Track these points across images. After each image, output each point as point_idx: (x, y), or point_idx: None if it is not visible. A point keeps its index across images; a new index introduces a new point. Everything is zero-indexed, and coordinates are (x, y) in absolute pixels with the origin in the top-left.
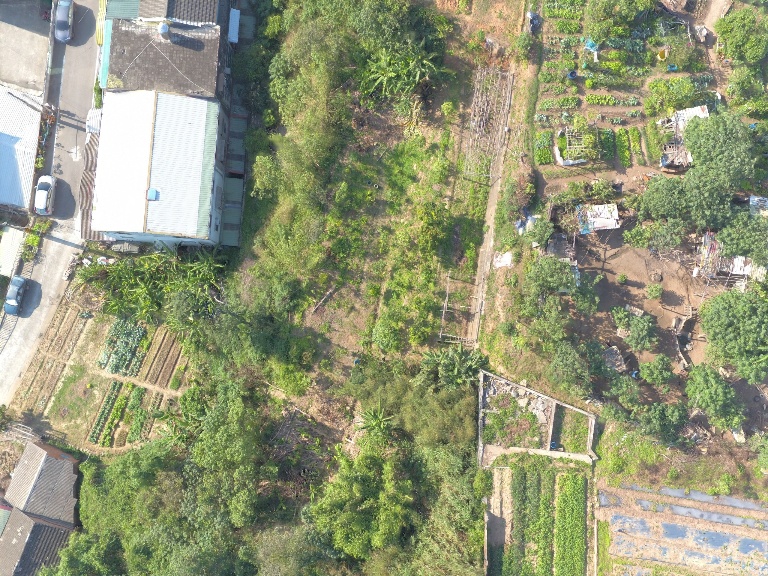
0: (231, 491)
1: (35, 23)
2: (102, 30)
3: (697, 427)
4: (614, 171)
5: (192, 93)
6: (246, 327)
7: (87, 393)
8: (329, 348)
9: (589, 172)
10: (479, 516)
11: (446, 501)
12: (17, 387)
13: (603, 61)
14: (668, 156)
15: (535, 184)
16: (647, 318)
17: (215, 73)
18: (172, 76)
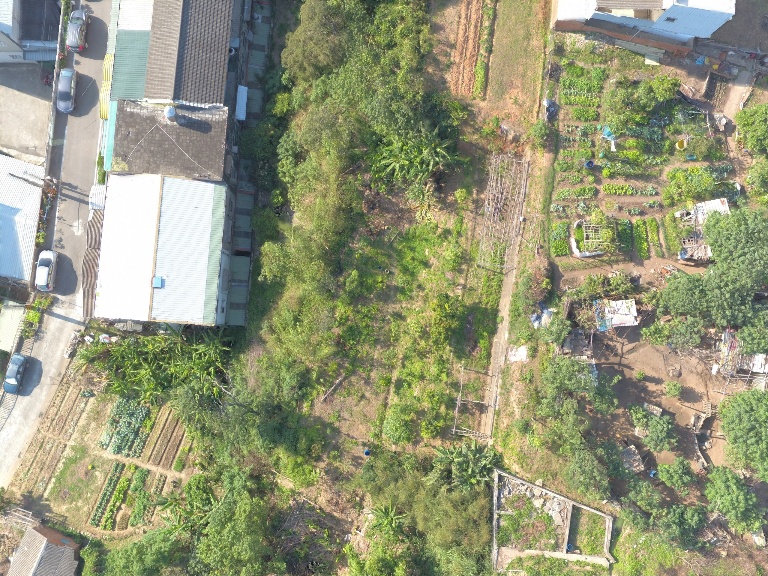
0: None
1: (36, 87)
2: (106, 104)
3: (717, 529)
4: (631, 263)
5: (199, 177)
6: (253, 414)
7: (88, 474)
8: (338, 438)
9: (606, 264)
10: None
11: None
12: (16, 468)
13: (620, 150)
14: (687, 250)
15: (551, 277)
16: (666, 419)
17: (222, 156)
18: (178, 159)
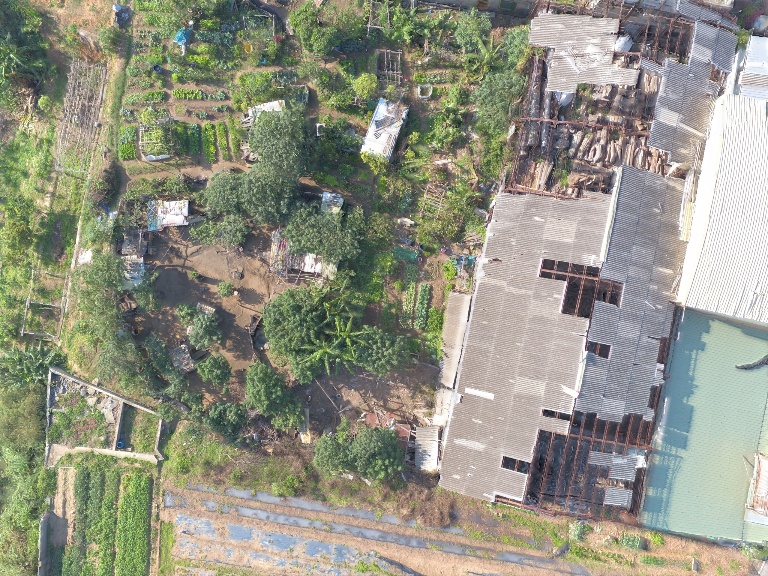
0: None
1: None
2: None
3: (265, 427)
4: (199, 167)
5: None
6: None
7: None
8: None
9: (173, 168)
10: (39, 517)
11: (14, 501)
12: None
13: (191, 55)
14: (244, 152)
15: (117, 180)
16: (209, 316)
17: None
18: None
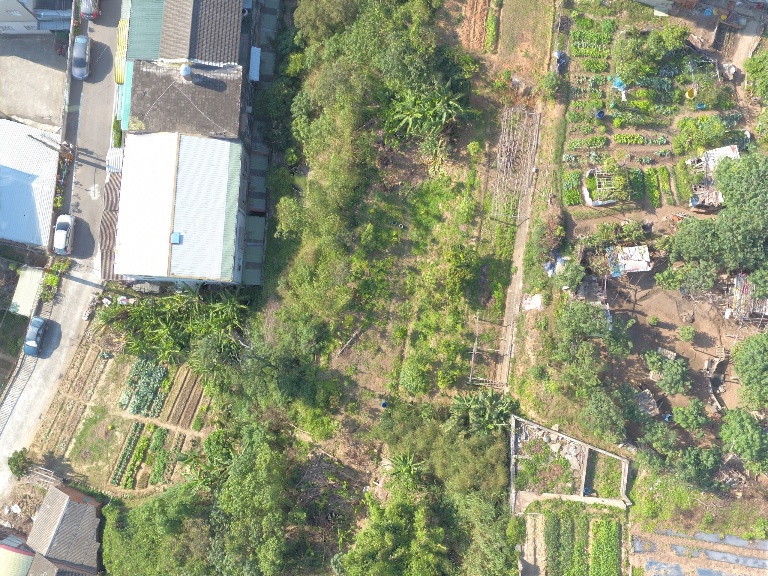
0: (260, 539)
1: (50, 57)
2: (121, 68)
3: (732, 471)
4: (643, 211)
5: (215, 134)
6: (271, 369)
7: (108, 434)
8: (356, 390)
9: (618, 213)
10: (513, 564)
11: (479, 548)
12: (37, 429)
13: (631, 100)
14: (698, 197)
15: (564, 225)
16: (680, 362)
17: (238, 114)
18: (194, 117)
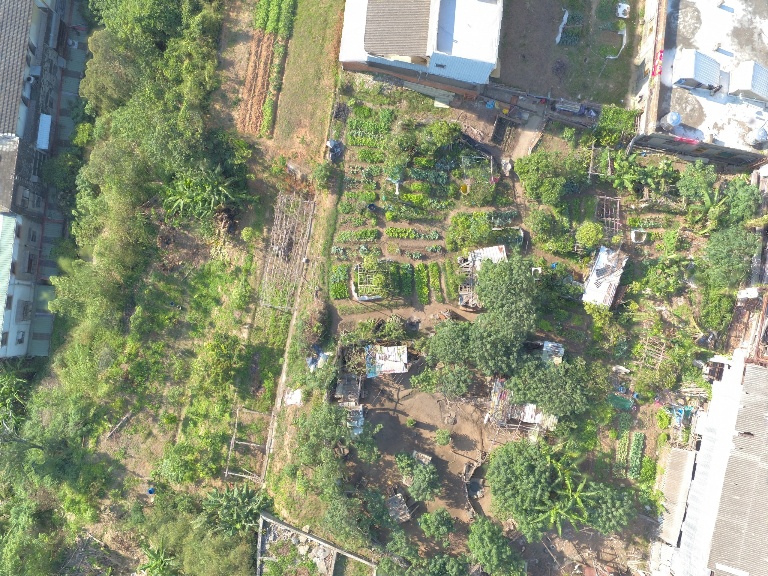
0: None
1: None
2: None
3: None
4: (412, 308)
5: None
6: None
7: None
8: (124, 475)
9: (385, 308)
10: None
11: None
12: None
13: (405, 193)
14: (463, 297)
15: (328, 320)
16: (431, 468)
17: (11, 187)
18: None
